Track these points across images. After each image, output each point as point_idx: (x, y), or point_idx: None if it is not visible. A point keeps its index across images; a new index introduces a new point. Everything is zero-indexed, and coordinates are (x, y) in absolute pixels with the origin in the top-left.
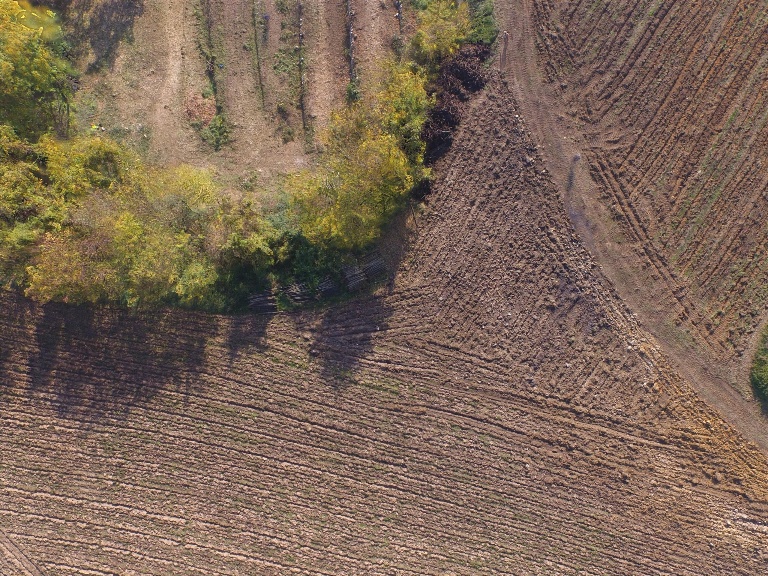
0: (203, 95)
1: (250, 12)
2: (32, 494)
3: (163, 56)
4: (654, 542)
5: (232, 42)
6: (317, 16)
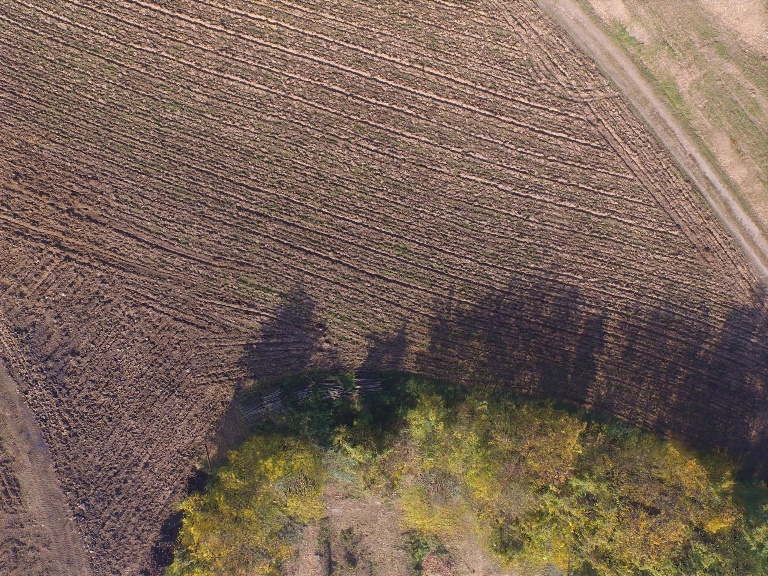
0: None
1: None
2: (609, 215)
3: None
4: None
5: None
6: None
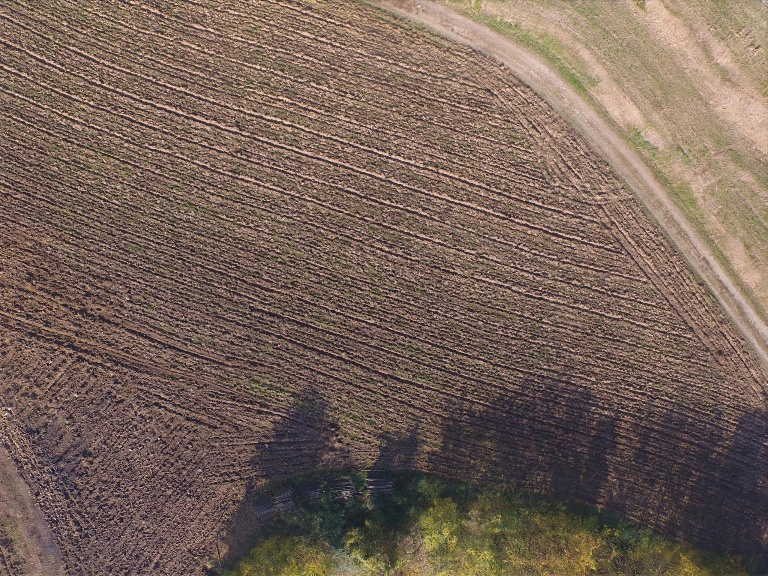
0: None
1: None
2: (622, 318)
3: None
4: (7, 213)
5: None
6: None
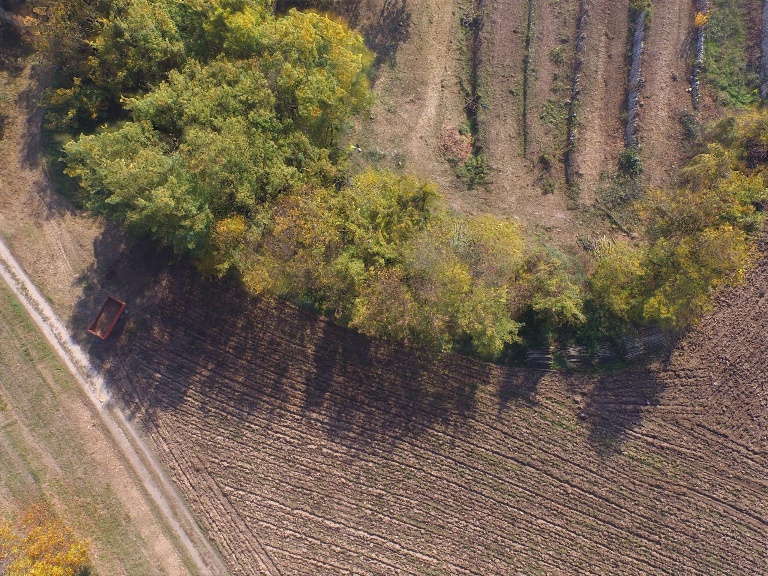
0: (460, 131)
1: (521, 57)
2: (292, 511)
3: (423, 86)
4: None
5: (498, 84)
6: (595, 74)
